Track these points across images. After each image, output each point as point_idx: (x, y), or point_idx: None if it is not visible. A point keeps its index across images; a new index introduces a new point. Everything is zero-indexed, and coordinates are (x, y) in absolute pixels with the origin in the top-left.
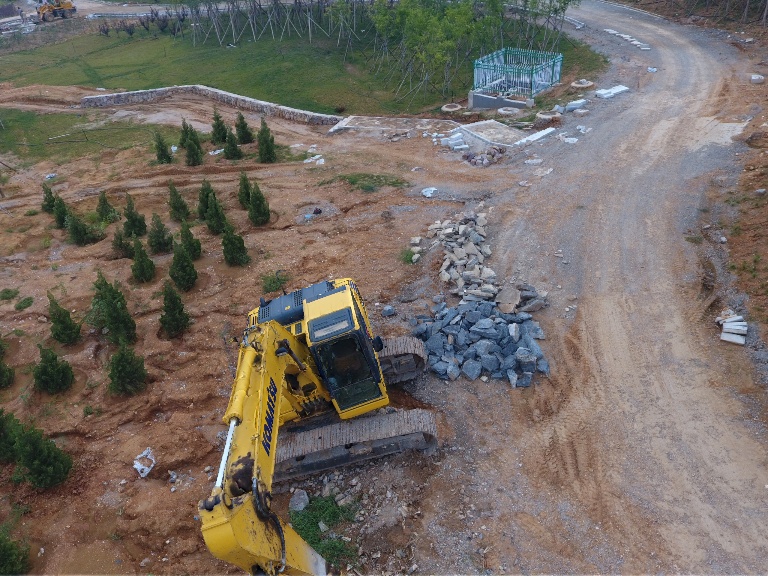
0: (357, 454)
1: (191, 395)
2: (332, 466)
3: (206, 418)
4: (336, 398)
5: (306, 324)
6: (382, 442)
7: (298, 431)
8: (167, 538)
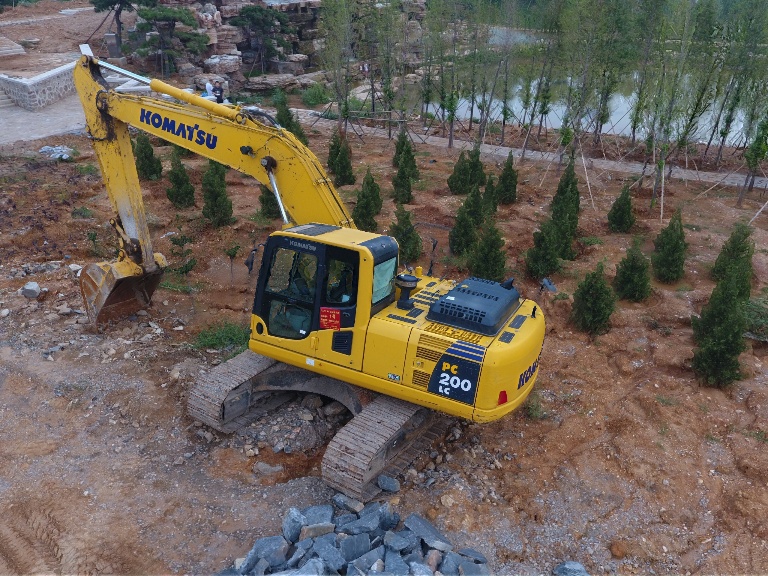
0: None
1: None
2: None
3: None
4: None
5: None
6: None
7: None
8: None
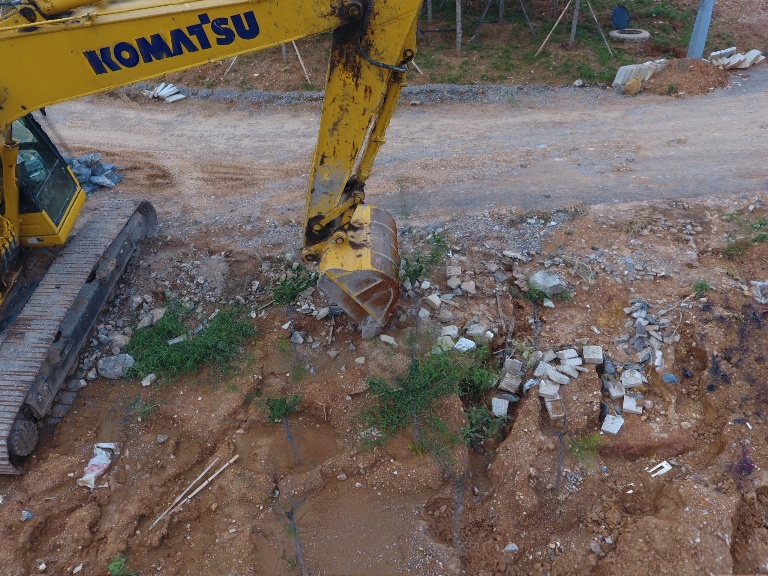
0: (110, 273)
1: None
2: (94, 317)
3: None
4: (44, 209)
5: None
6: (116, 247)
7: (7, 325)
8: (32, 571)
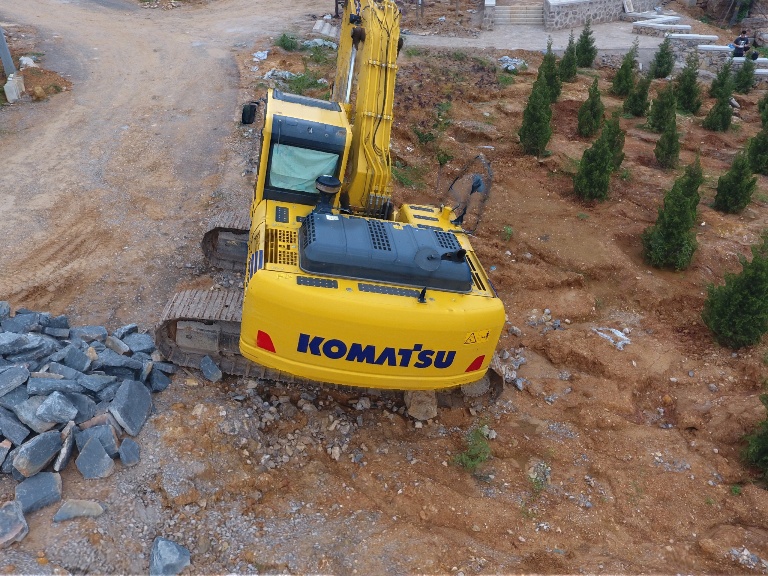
0: None
1: (619, 419)
2: None
3: (564, 389)
4: None
5: (344, 110)
6: None
7: None
8: None
